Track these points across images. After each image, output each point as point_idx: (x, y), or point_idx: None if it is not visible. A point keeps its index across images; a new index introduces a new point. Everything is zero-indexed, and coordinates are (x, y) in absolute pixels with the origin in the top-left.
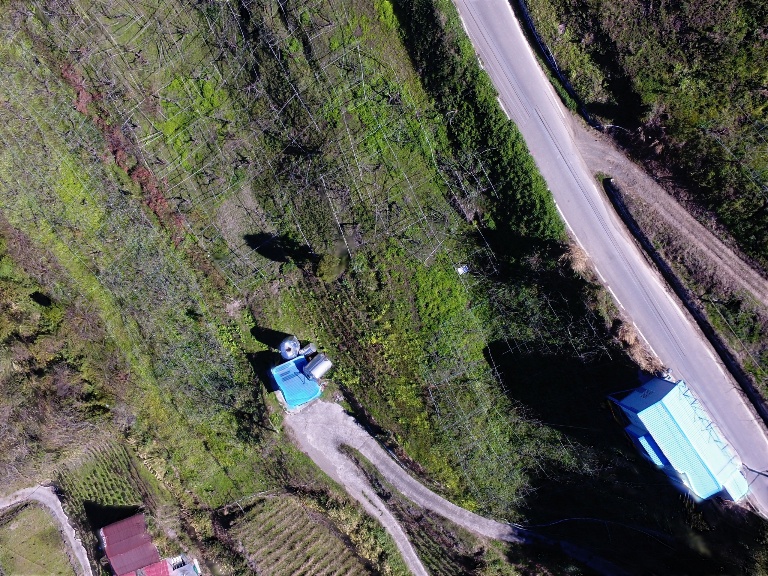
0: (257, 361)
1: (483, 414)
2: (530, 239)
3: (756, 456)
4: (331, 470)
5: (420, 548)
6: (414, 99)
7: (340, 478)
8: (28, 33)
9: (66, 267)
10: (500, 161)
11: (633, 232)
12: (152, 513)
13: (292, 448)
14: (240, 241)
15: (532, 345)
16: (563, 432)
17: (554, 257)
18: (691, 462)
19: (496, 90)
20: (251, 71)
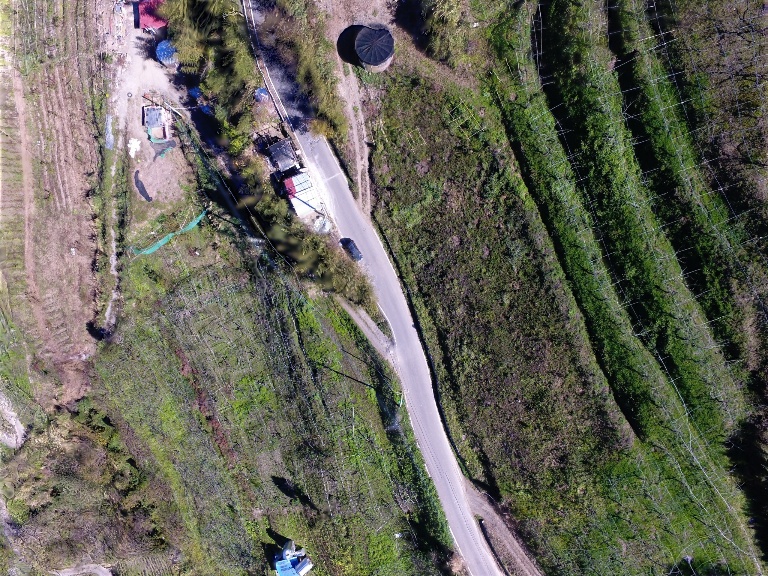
0: (267, 549)
1: None
2: (435, 539)
3: None
4: None
5: None
6: (381, 441)
7: None
8: (159, 323)
9: (154, 453)
10: (423, 494)
11: (493, 550)
12: None
13: None
14: (268, 478)
15: None
16: None
17: None
18: None
19: (425, 460)
20: (291, 393)
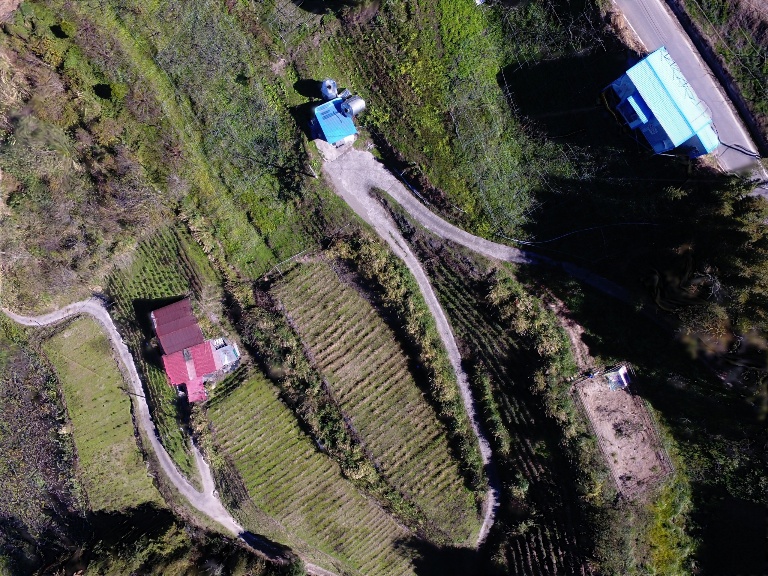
0: (299, 113)
1: (496, 135)
2: None
3: (726, 132)
4: (363, 212)
5: (440, 286)
6: None
7: (370, 220)
8: None
9: (127, 52)
10: None
11: None
12: (197, 296)
13: (329, 192)
14: None
15: (539, 56)
16: (565, 142)
17: None
18: (670, 112)
19: None
20: None
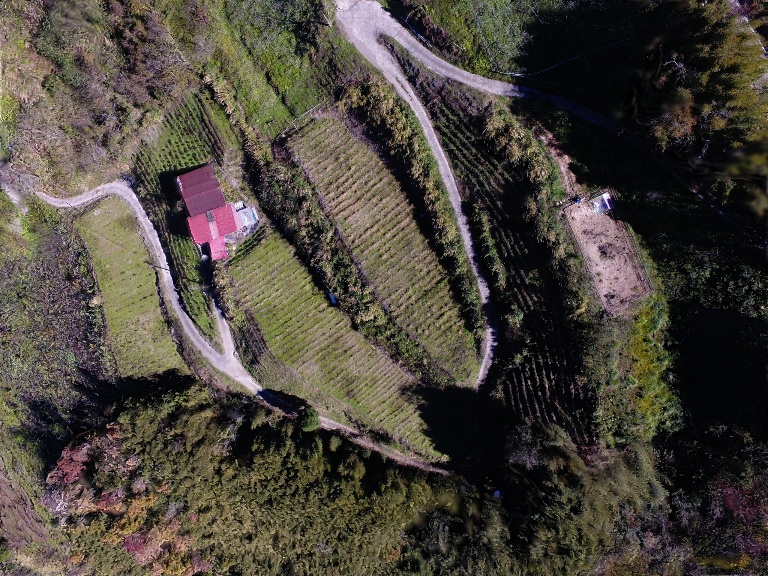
0: None
1: None
2: None
3: None
4: (372, 58)
5: (441, 128)
6: None
7: (379, 65)
8: None
9: None
10: None
11: None
12: (219, 161)
13: (341, 39)
14: None
15: None
16: None
17: None
18: None
19: None
20: None
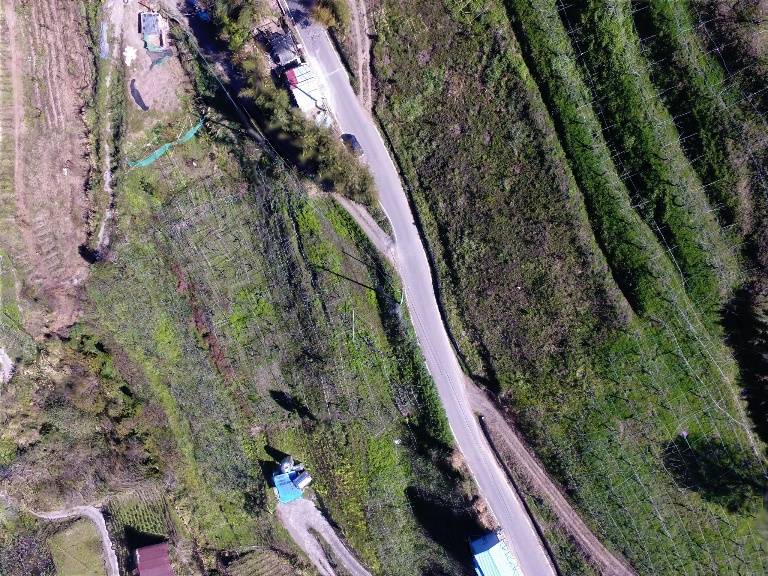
0: (265, 467)
1: (399, 528)
2: (435, 439)
3: None
4: (301, 543)
5: None
6: (381, 345)
7: (306, 549)
8: (155, 240)
9: (149, 377)
10: (423, 394)
11: (492, 447)
12: (174, 544)
13: (279, 525)
14: (266, 393)
15: (431, 496)
16: (445, 549)
17: None
18: None
19: (425, 357)
20: (290, 302)
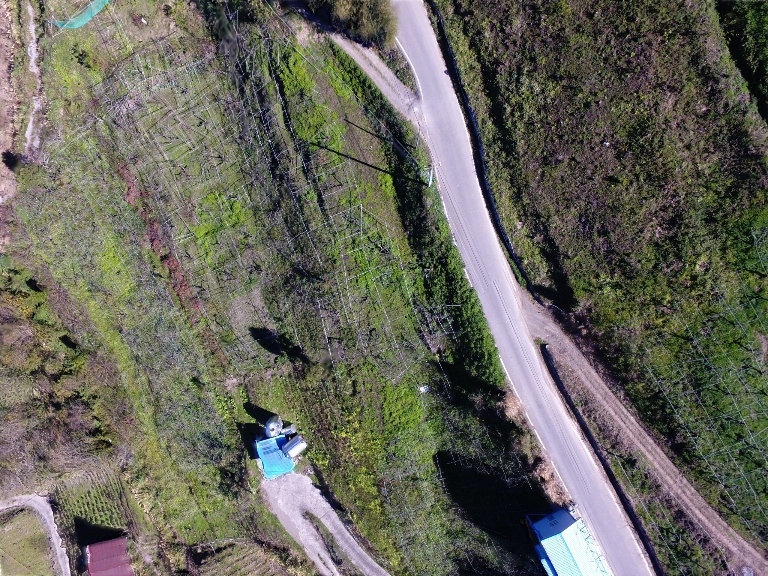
0: (245, 431)
1: (426, 509)
2: (478, 380)
3: None
4: (294, 532)
5: None
6: (401, 252)
7: (301, 540)
8: (96, 133)
9: (95, 321)
10: (461, 316)
11: (560, 388)
12: (134, 539)
13: (264, 509)
14: (245, 331)
15: (471, 462)
16: (490, 535)
17: (494, 401)
18: None
19: (464, 262)
20: (274, 202)
